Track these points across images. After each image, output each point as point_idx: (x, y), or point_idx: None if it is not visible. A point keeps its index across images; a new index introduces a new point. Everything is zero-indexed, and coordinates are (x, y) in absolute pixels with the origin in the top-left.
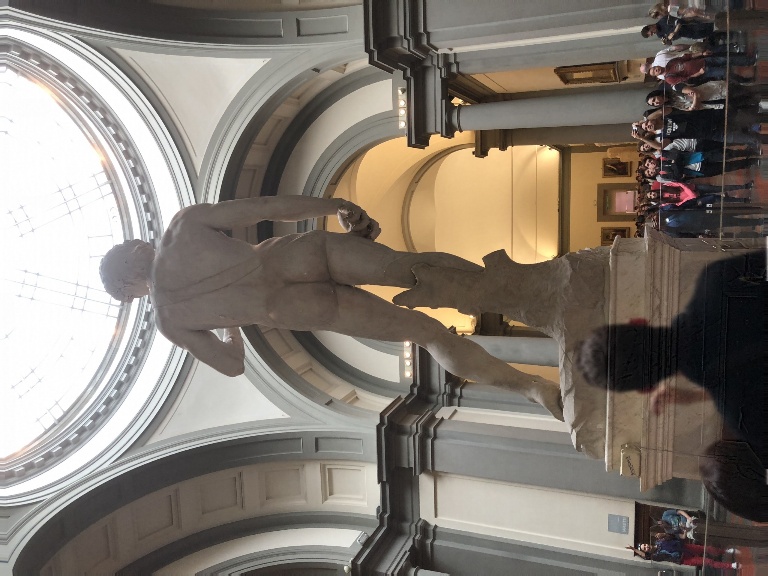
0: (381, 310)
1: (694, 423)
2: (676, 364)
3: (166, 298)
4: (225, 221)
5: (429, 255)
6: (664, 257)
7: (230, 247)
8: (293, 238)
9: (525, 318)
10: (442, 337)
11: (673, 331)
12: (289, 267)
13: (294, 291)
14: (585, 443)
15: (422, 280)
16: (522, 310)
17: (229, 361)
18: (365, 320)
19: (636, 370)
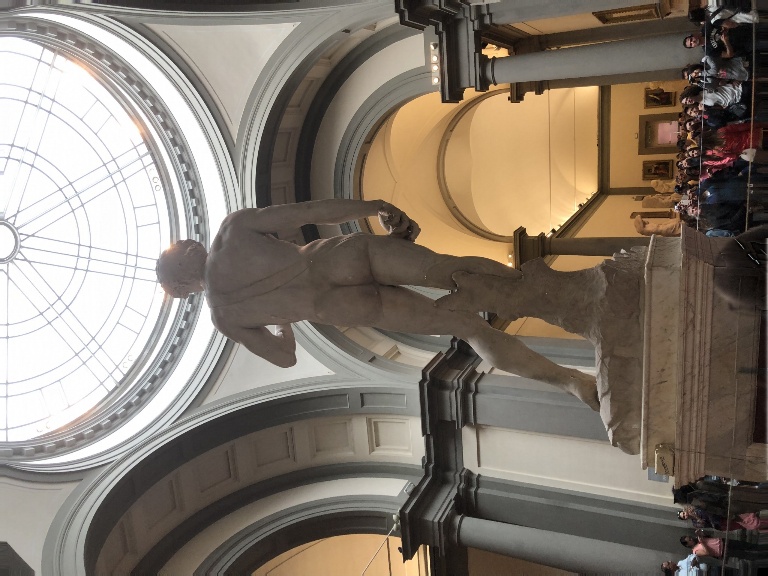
0: (423, 309)
1: (726, 427)
2: (709, 372)
3: (220, 300)
4: (271, 226)
5: (468, 261)
6: (698, 273)
7: (277, 251)
8: (337, 242)
9: (562, 325)
10: (482, 332)
11: (706, 342)
12: (334, 272)
13: (340, 294)
14: (621, 441)
15: (462, 287)
16: (559, 317)
17: (281, 355)
18: (408, 319)
19: (670, 377)
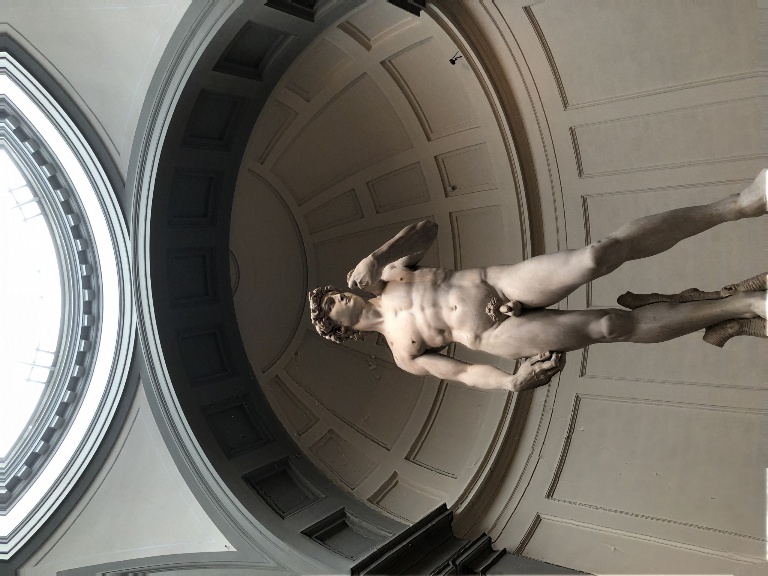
0: None
1: None
2: None
3: None
4: None
5: None
6: None
7: None
8: None
9: None
10: None
11: None
12: None
13: None
14: None
15: None
16: None
17: None
18: None
19: None
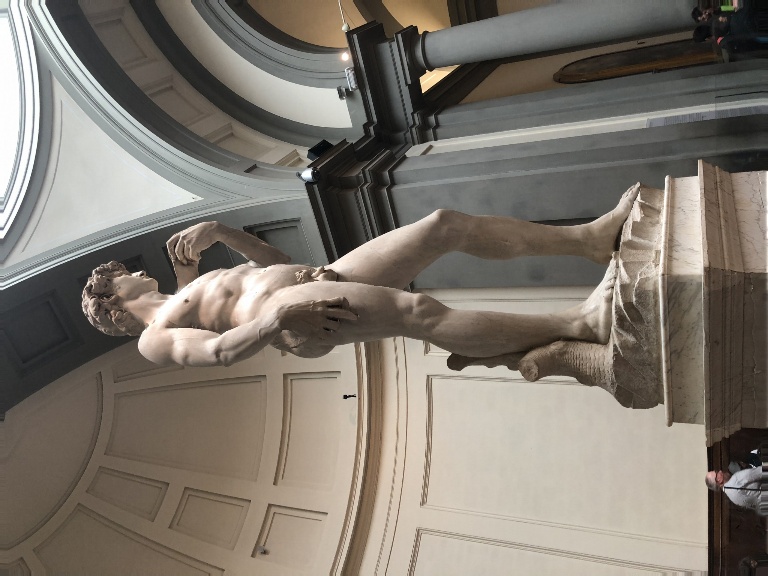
0: None
1: None
2: None
3: None
4: None
5: None
6: None
7: None
8: None
9: None
10: None
11: None
12: None
13: None
14: None
15: None
16: None
17: None
18: None
19: None
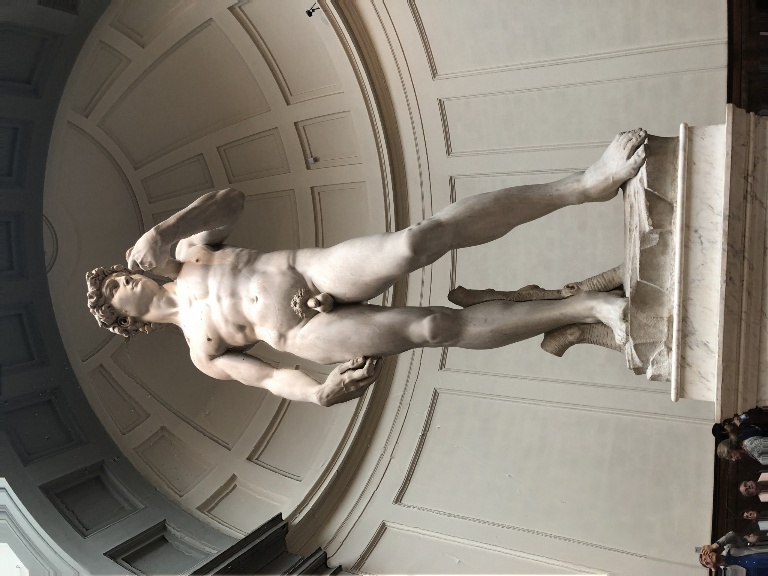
0: None
1: None
2: None
3: None
4: None
5: None
6: None
7: None
8: None
9: None
10: None
11: None
12: None
13: None
14: None
15: None
16: None
17: None
18: None
19: None
